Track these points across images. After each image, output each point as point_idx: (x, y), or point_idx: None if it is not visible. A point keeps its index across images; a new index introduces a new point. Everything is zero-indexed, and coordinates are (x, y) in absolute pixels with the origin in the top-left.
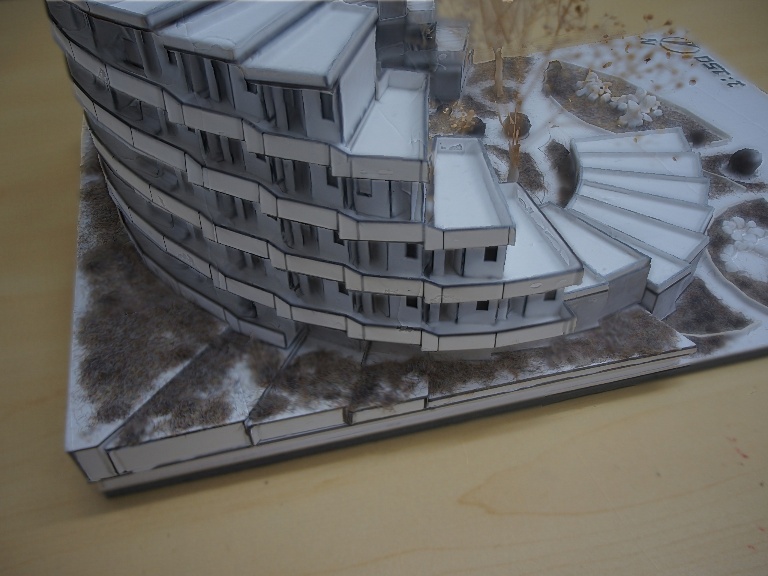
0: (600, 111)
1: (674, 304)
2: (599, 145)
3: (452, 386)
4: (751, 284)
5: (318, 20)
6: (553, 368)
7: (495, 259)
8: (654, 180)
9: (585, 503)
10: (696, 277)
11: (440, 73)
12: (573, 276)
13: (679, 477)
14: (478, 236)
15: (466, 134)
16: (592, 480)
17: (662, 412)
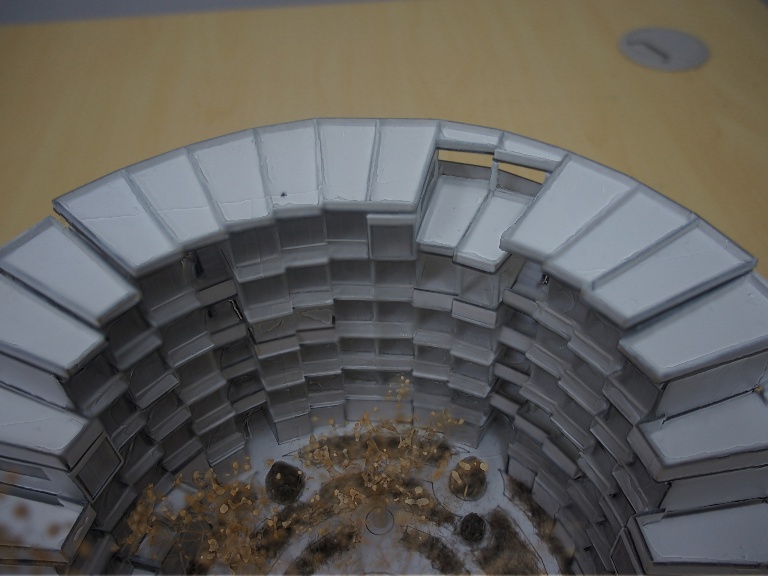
0: None
1: None
2: None
3: None
4: None
5: (80, 326)
6: None
7: None
8: None
9: None
10: None
11: None
12: None
13: None
14: None
15: None
16: None
17: None
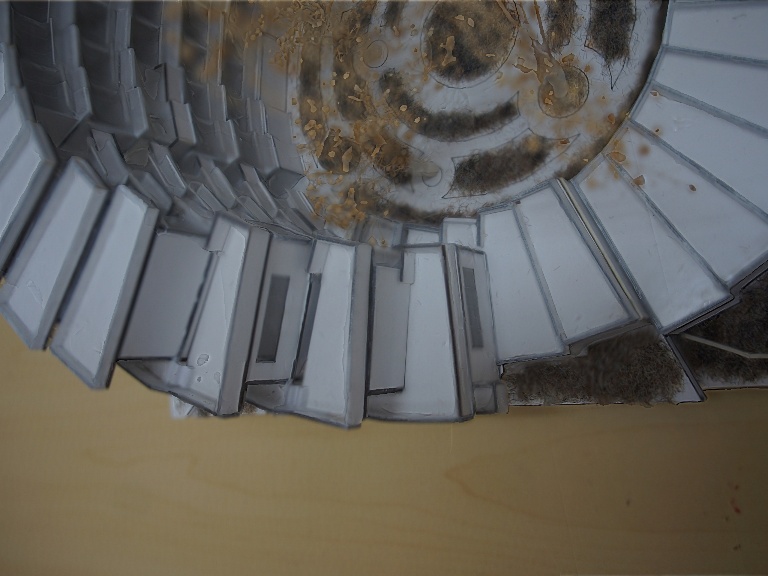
0: None
1: (736, 297)
2: None
3: None
4: None
5: (110, 223)
6: (521, 400)
7: None
8: None
9: (543, 513)
10: None
11: None
12: None
13: (647, 513)
14: None
15: None
16: (558, 492)
17: (667, 432)
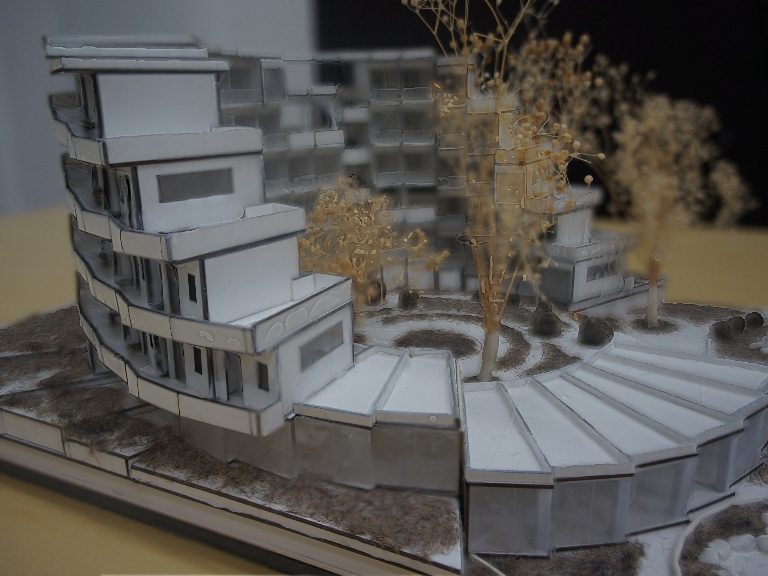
0: None
1: (547, 546)
2: (643, 357)
3: (162, 464)
4: None
5: None
6: (265, 499)
7: (196, 299)
8: (661, 400)
9: None
10: (640, 544)
11: (551, 269)
12: (241, 337)
13: None
14: (141, 241)
15: (534, 327)
16: None
17: None
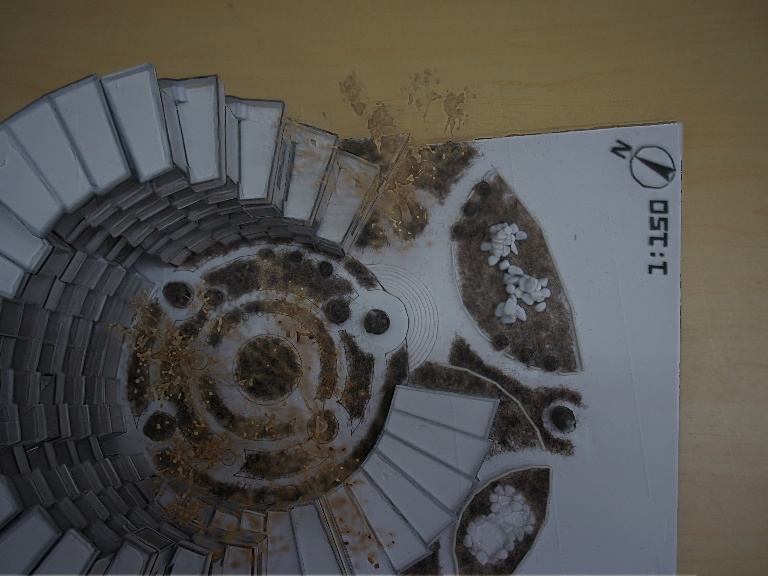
0: (489, 283)
1: None
2: (418, 399)
3: None
4: (472, 561)
5: None
6: None
7: None
8: (436, 464)
9: None
10: None
11: (322, 245)
12: None
13: None
14: None
15: None
16: None
17: None
